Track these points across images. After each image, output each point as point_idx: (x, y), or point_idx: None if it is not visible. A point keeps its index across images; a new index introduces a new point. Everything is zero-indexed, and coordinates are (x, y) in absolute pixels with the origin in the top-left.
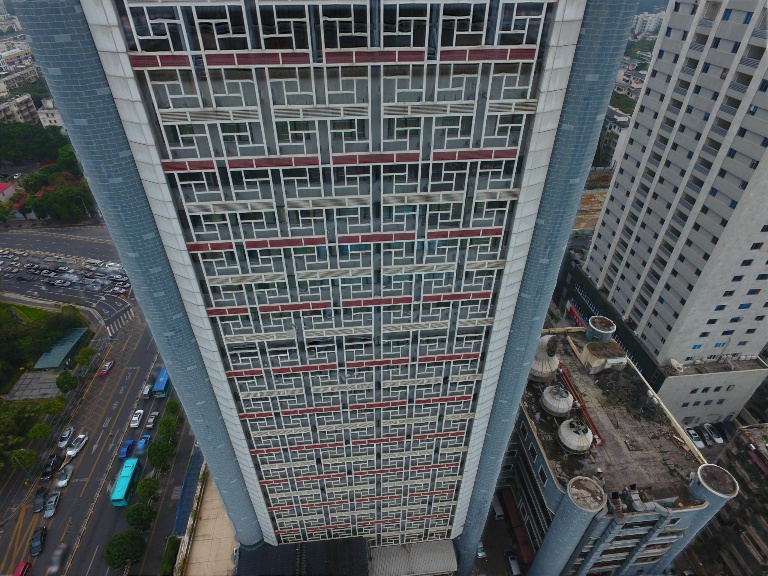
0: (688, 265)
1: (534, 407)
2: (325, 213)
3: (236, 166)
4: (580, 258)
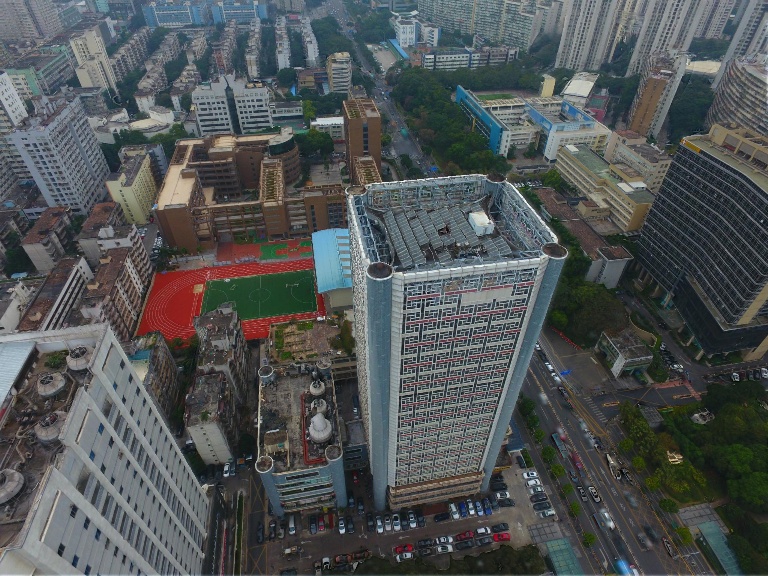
0: None
1: (330, 412)
2: None
3: None
4: None
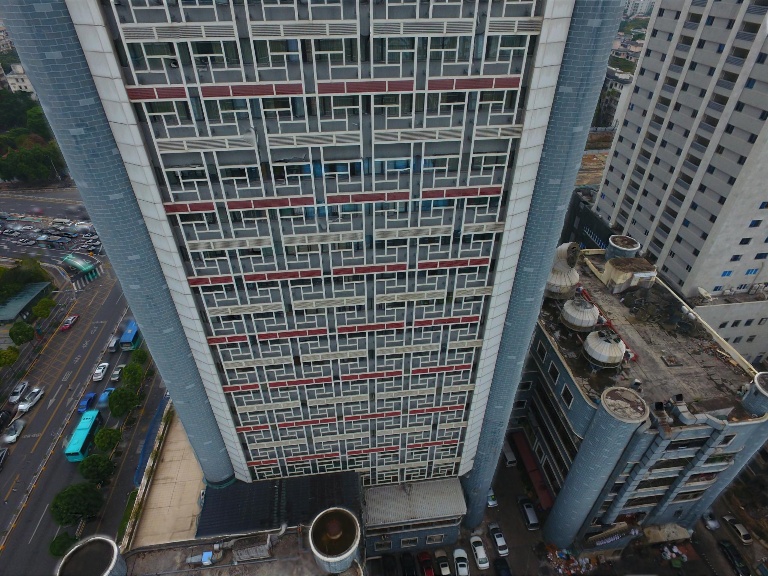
0: (719, 175)
1: (552, 325)
2: None
3: None
4: (588, 200)
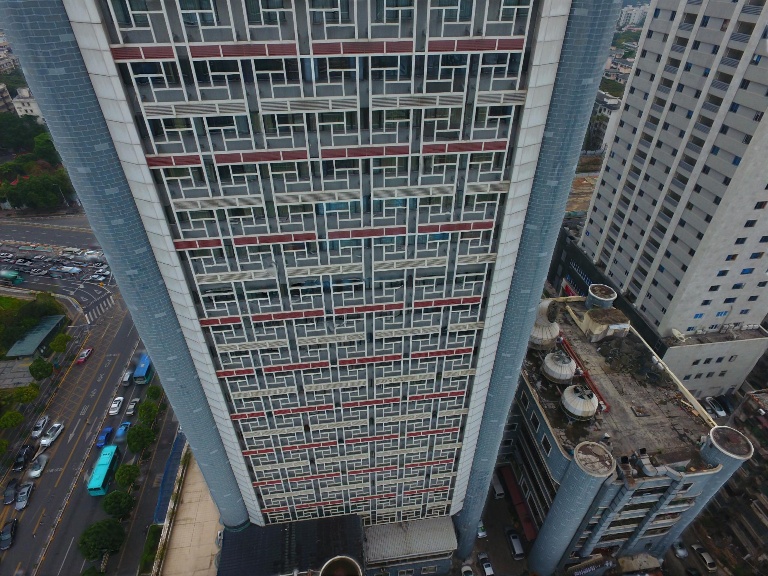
0: (689, 229)
1: (535, 375)
2: (306, 119)
3: (200, 54)
4: (575, 235)
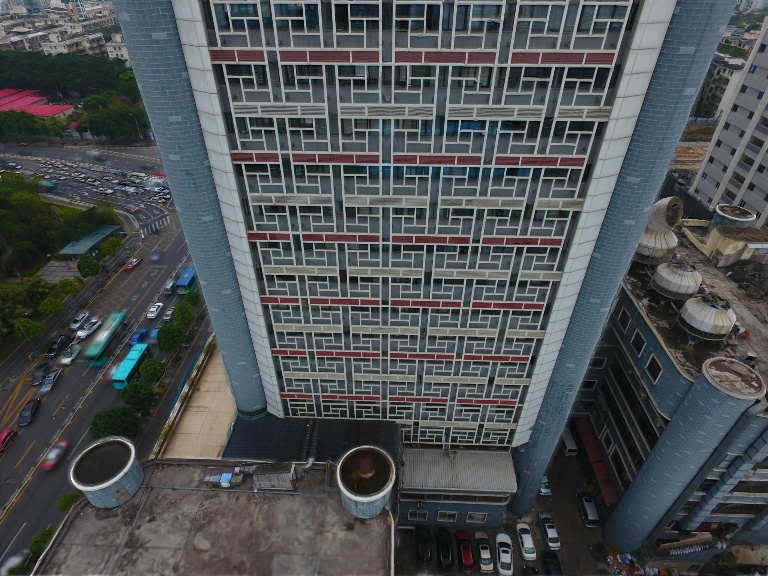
0: None
1: (640, 291)
2: None
3: None
4: (685, 183)
